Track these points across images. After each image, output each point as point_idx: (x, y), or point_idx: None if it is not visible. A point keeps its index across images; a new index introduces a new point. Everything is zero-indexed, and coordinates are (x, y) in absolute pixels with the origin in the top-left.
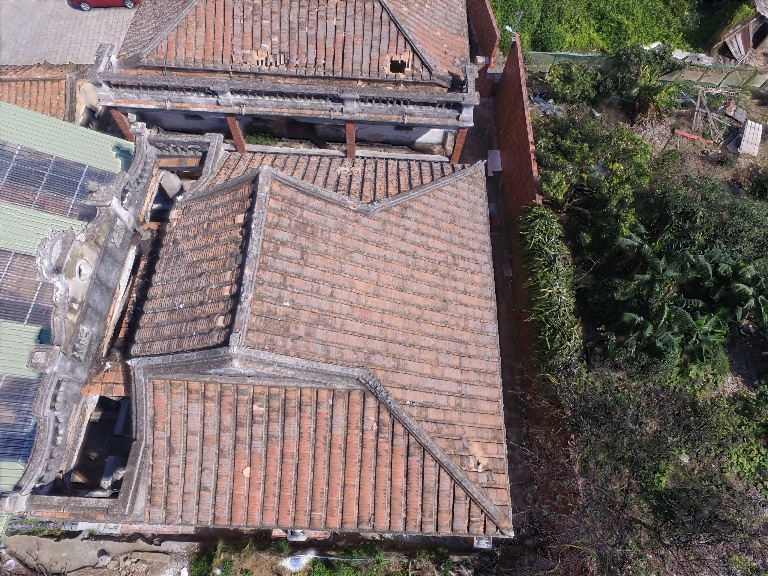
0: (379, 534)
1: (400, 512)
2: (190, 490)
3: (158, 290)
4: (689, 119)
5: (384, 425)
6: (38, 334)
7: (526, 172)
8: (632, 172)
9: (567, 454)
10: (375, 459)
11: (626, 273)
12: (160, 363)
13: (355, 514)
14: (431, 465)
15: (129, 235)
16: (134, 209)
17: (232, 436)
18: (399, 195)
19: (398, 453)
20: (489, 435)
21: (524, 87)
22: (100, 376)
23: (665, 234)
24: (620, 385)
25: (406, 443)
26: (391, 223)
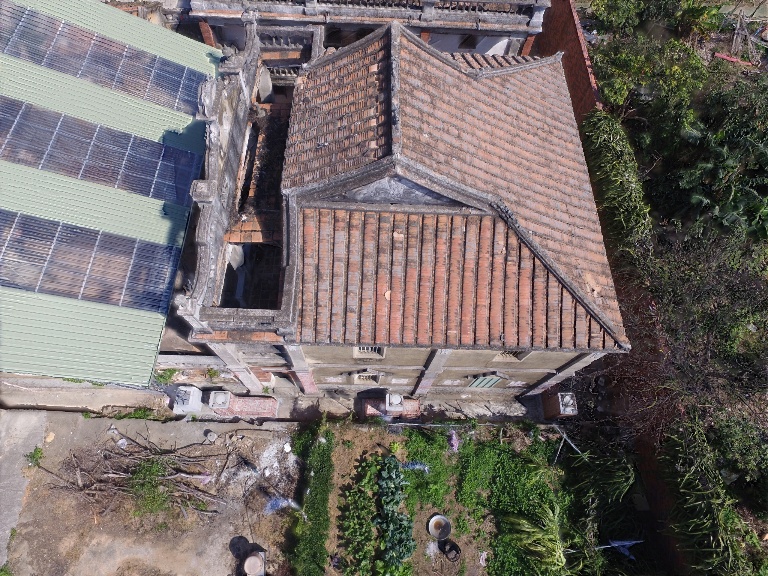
0: (464, 415)
1: (527, 330)
2: (337, 311)
3: (297, 138)
4: (728, 44)
5: (512, 249)
6: (162, 206)
7: (582, 87)
8: (689, 75)
9: (650, 317)
10: (503, 282)
11: (688, 167)
12: (315, 187)
13: (486, 333)
14: (555, 286)
15: (247, 112)
16: (249, 90)
17: (374, 262)
18: (498, 68)
19: (525, 275)
20: (598, 270)
21: (575, 12)
22: (238, 225)
23: (726, 126)
24: (686, 269)
25: (531, 267)
26: (494, 90)
